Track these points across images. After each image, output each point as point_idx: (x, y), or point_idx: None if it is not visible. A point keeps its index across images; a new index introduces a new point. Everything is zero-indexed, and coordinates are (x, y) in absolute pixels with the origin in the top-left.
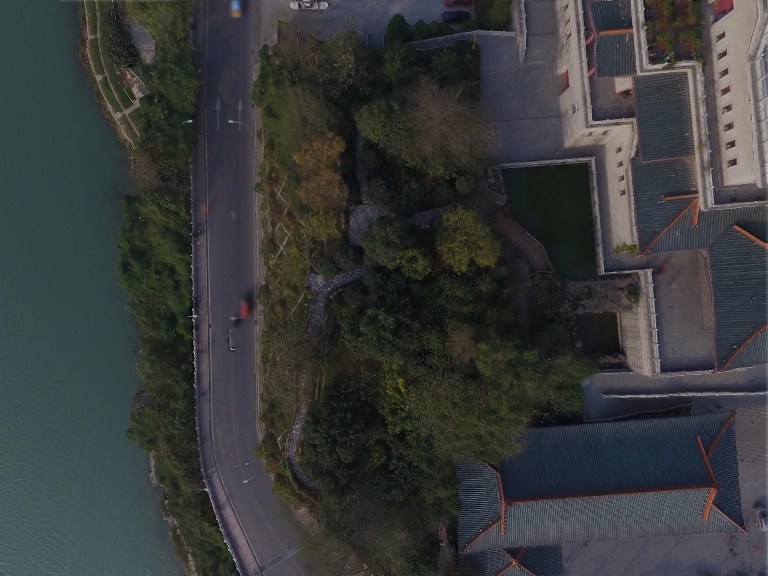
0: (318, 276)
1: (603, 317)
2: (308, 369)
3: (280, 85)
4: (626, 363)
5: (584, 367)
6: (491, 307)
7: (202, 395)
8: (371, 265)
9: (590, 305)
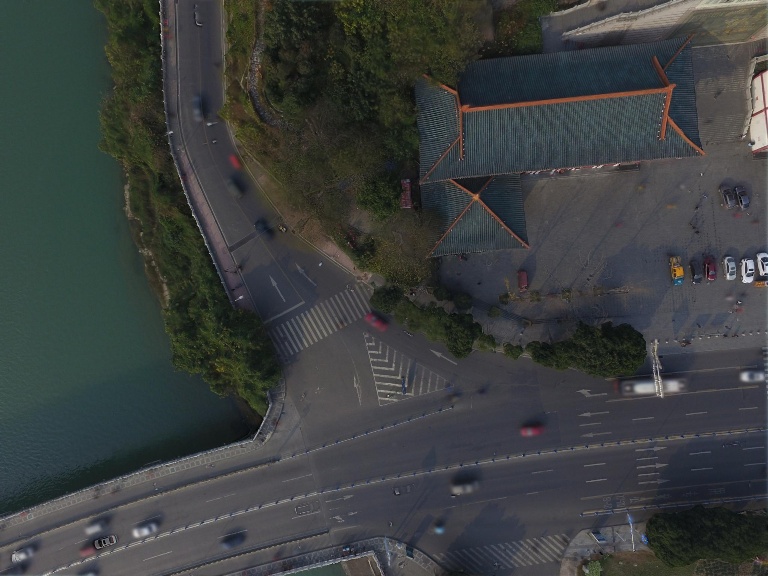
0: None
1: None
2: None
3: None
4: None
5: None
6: None
7: (169, 71)
8: None
9: None
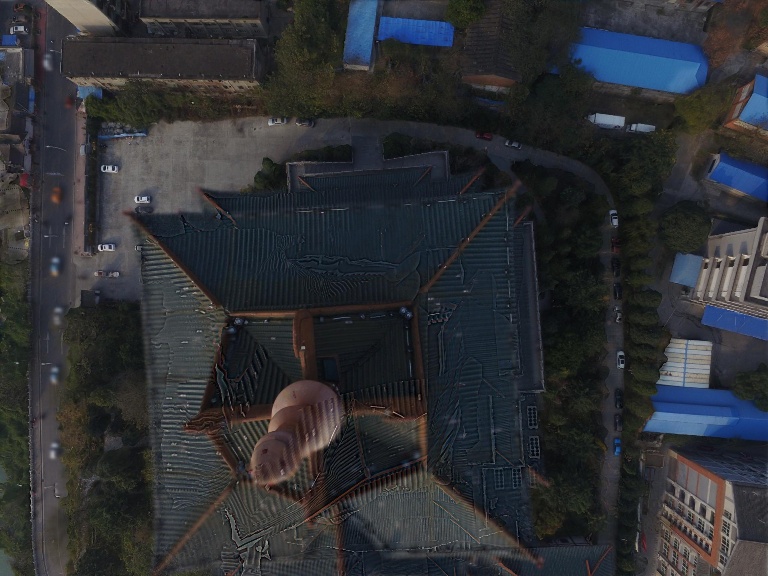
0: None
1: None
2: (86, 525)
3: (75, 341)
4: None
5: None
6: None
7: (37, 526)
8: None
9: None
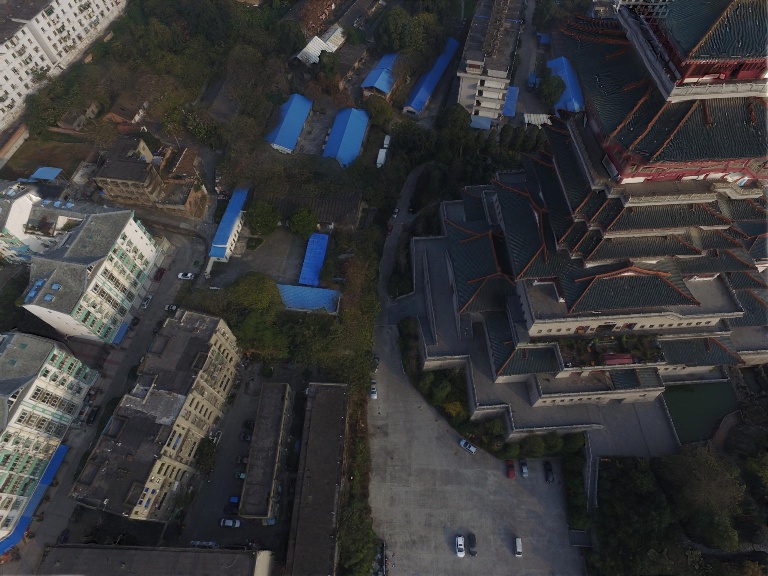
0: None
1: None
2: None
3: None
4: (764, 364)
5: None
6: None
7: None
8: None
9: None
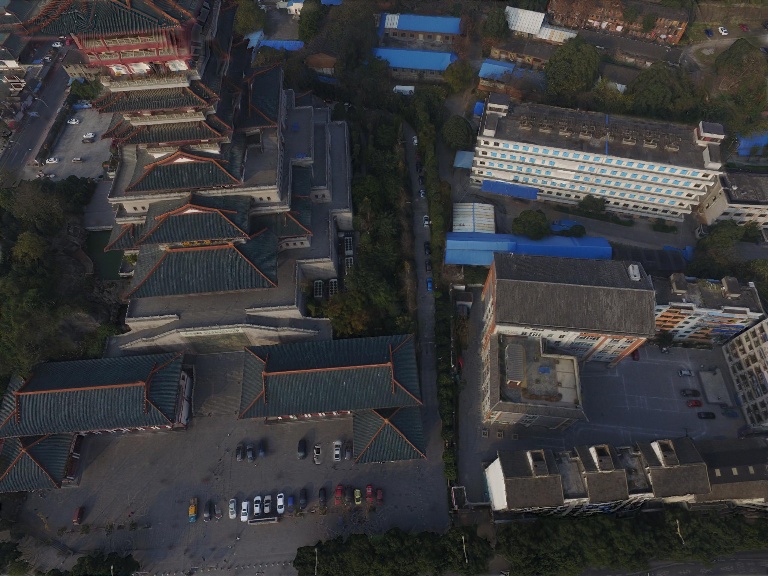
0: None
1: None
2: None
3: None
4: None
5: (106, 328)
6: None
7: None
8: None
9: (114, 293)
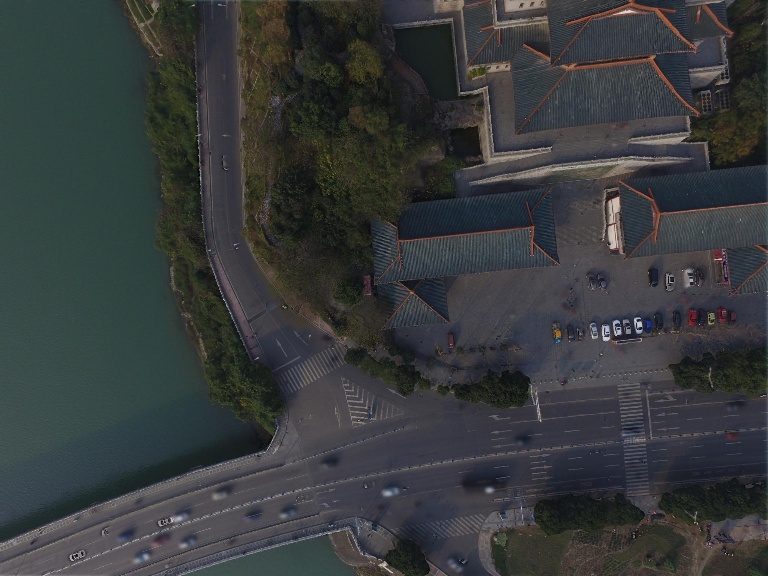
0: (276, 97)
1: (471, 134)
2: (273, 162)
3: None
4: (483, 160)
5: (453, 161)
6: (382, 106)
7: (206, 201)
8: (307, 81)
9: (454, 117)
